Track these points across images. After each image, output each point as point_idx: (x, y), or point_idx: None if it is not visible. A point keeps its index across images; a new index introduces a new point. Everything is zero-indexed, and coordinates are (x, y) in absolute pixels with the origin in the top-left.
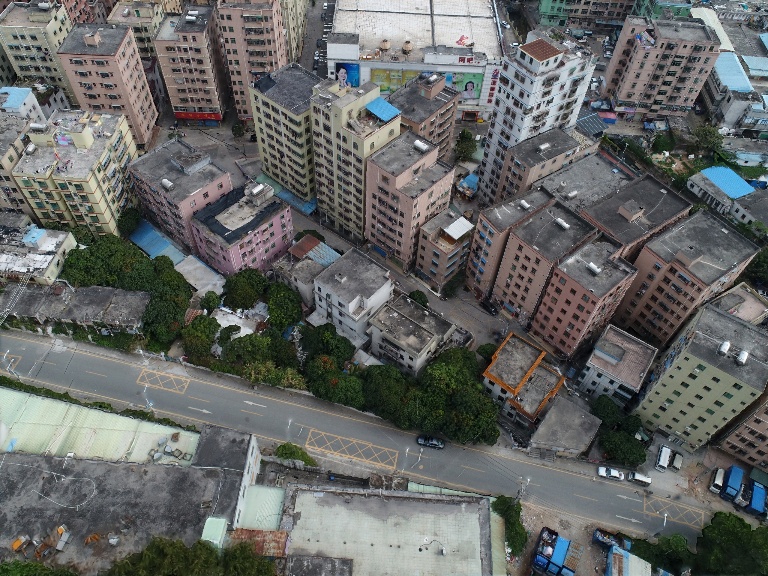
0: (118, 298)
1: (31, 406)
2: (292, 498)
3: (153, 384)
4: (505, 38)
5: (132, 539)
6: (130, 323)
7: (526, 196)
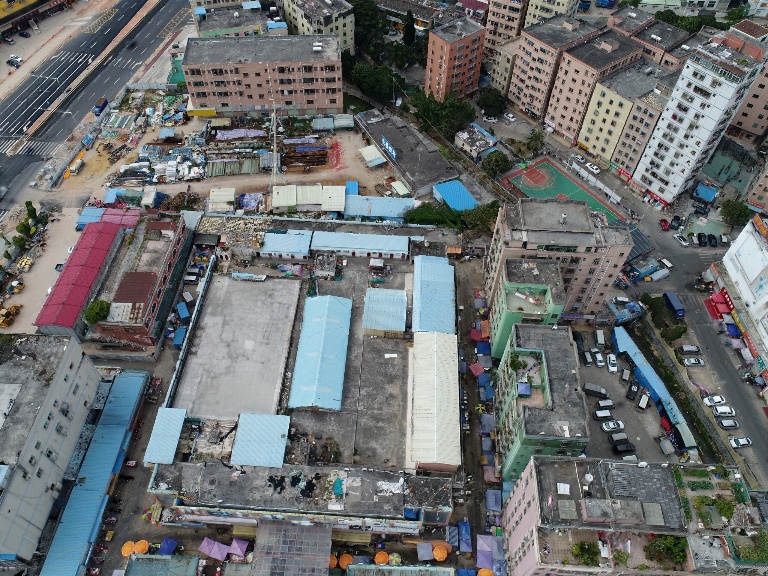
0: None
1: None
2: None
3: None
4: (767, 473)
5: None
6: None
7: (686, 57)
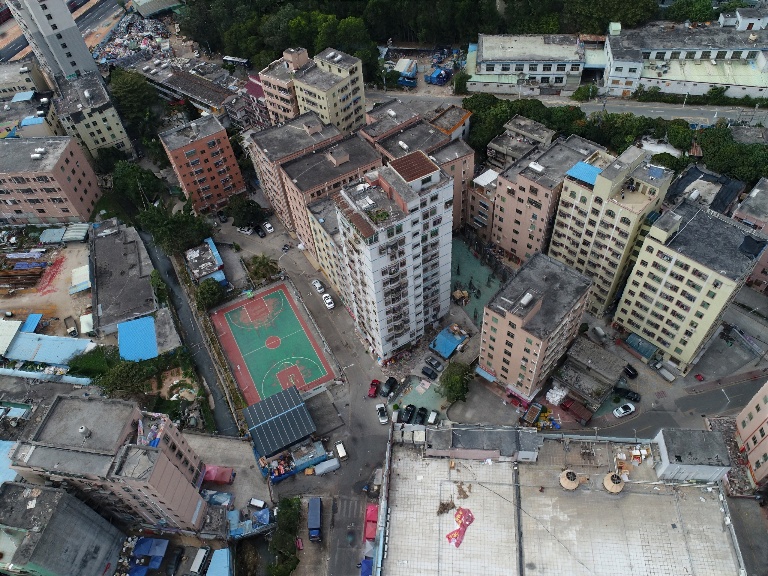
0: (761, 141)
1: (760, 82)
2: (581, 58)
3: (696, 119)
4: None
5: (654, 30)
6: (736, 127)
7: None
